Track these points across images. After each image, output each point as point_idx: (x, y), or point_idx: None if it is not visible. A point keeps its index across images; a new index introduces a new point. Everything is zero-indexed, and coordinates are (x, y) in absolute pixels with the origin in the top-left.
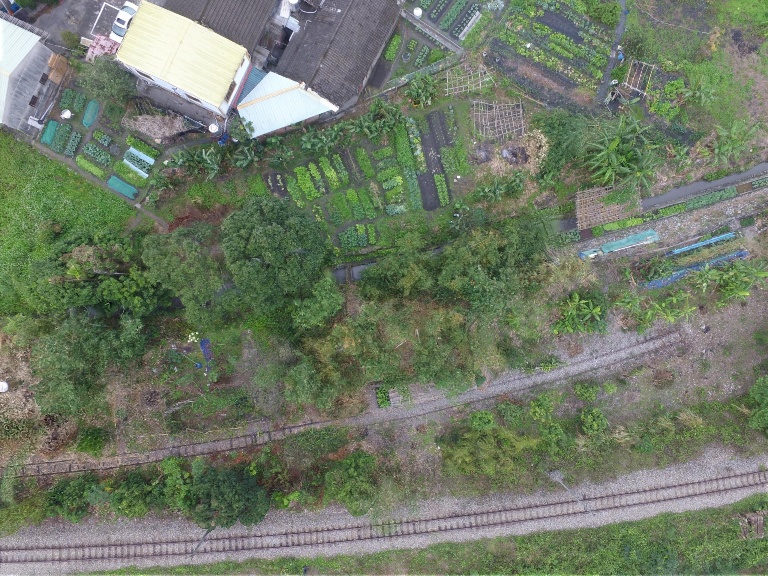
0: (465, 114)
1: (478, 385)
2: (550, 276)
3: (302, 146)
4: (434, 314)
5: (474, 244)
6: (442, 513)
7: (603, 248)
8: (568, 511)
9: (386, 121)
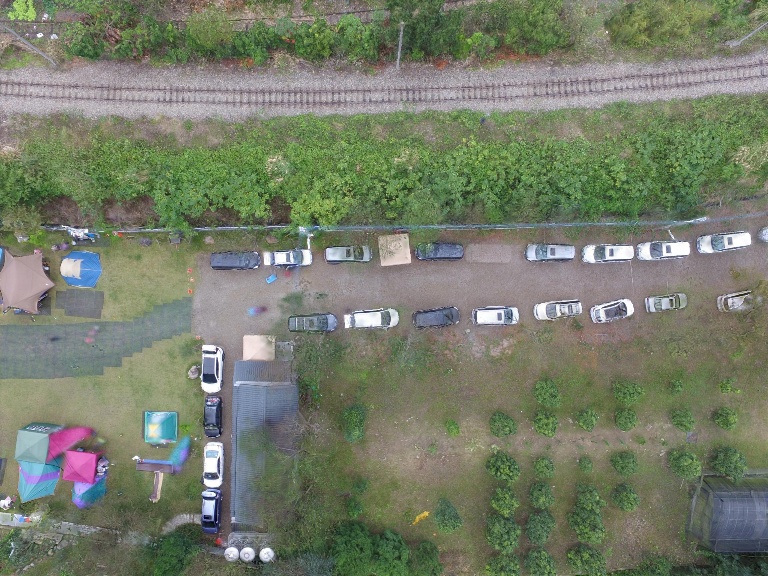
0: None
1: None
2: None
3: None
4: None
5: None
6: (618, 74)
7: None
8: (745, 75)
9: None
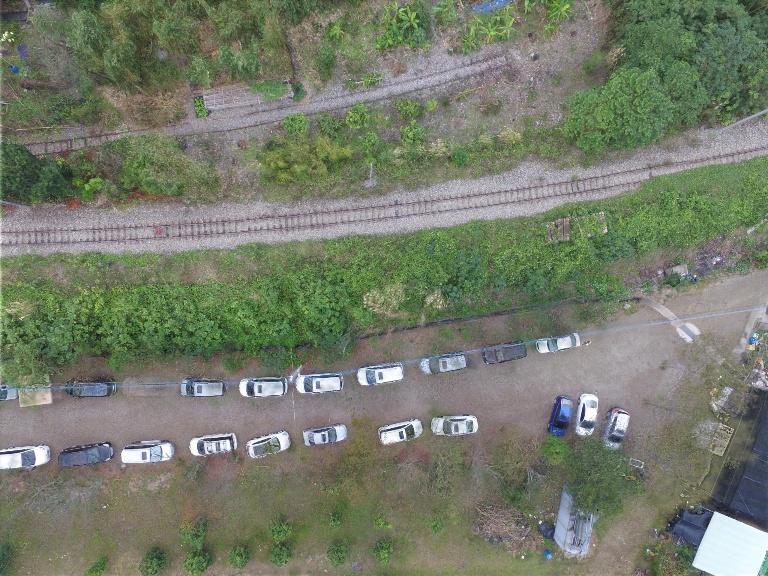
0: None
1: (299, 99)
2: None
3: None
4: None
5: None
6: (252, 215)
7: None
8: (379, 216)
9: None
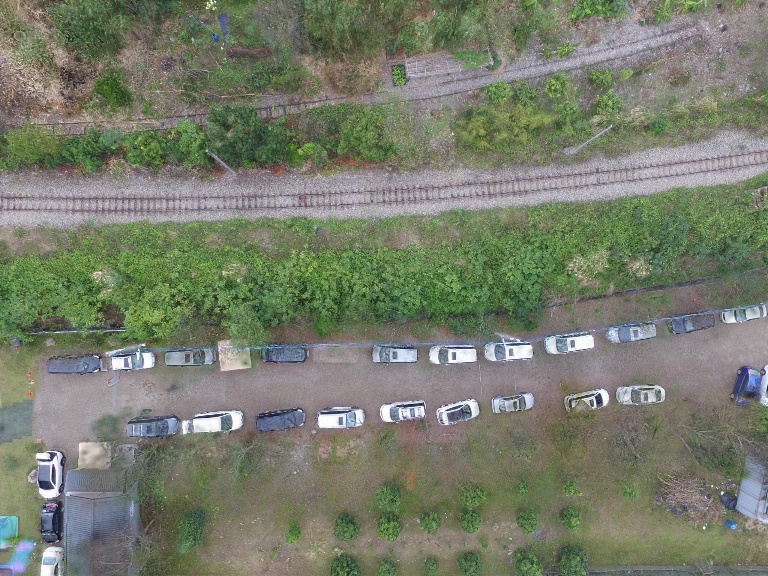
0: None
1: (494, 68)
2: None
3: None
4: None
5: None
6: (455, 181)
7: None
8: (581, 183)
9: None
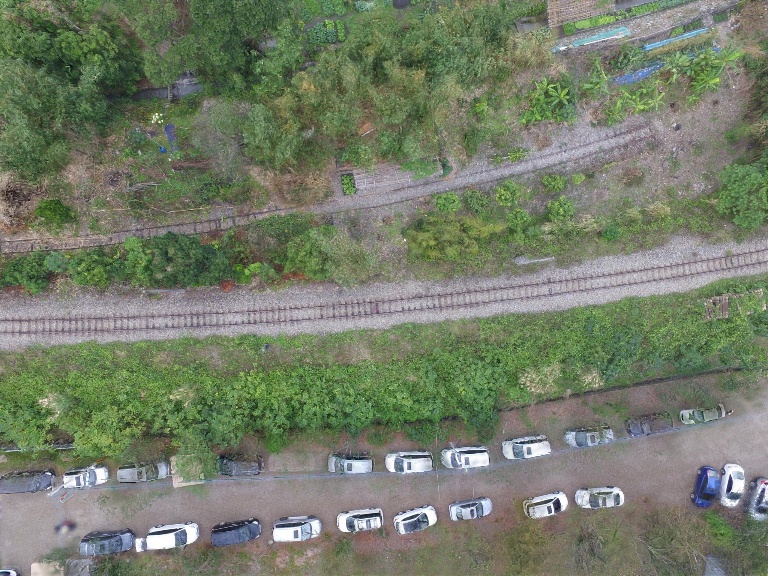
0: None
1: (445, 175)
2: (517, 48)
3: None
4: (397, 73)
5: (440, 16)
6: (406, 294)
7: (574, 43)
8: (533, 294)
9: None
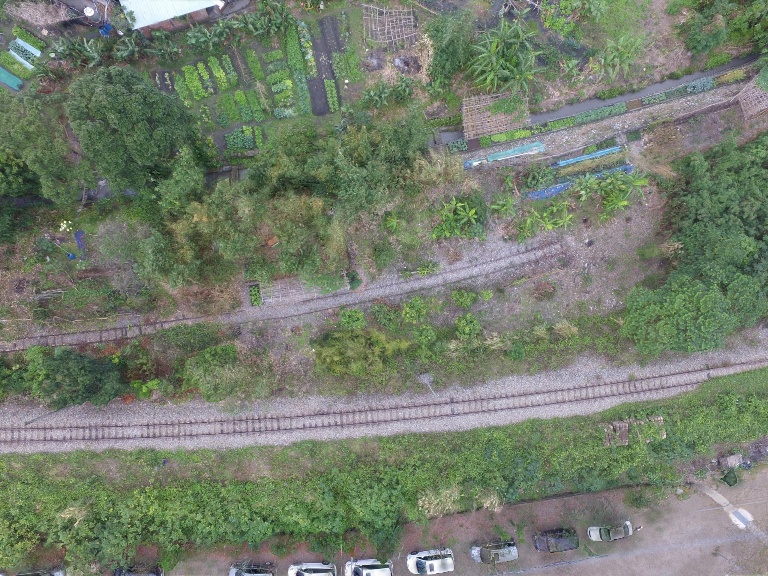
0: (358, 20)
1: (354, 287)
2: (421, 172)
3: (187, 41)
4: (296, 200)
5: (347, 138)
6: (307, 411)
7: (488, 157)
8: (435, 413)
9: (272, 19)
